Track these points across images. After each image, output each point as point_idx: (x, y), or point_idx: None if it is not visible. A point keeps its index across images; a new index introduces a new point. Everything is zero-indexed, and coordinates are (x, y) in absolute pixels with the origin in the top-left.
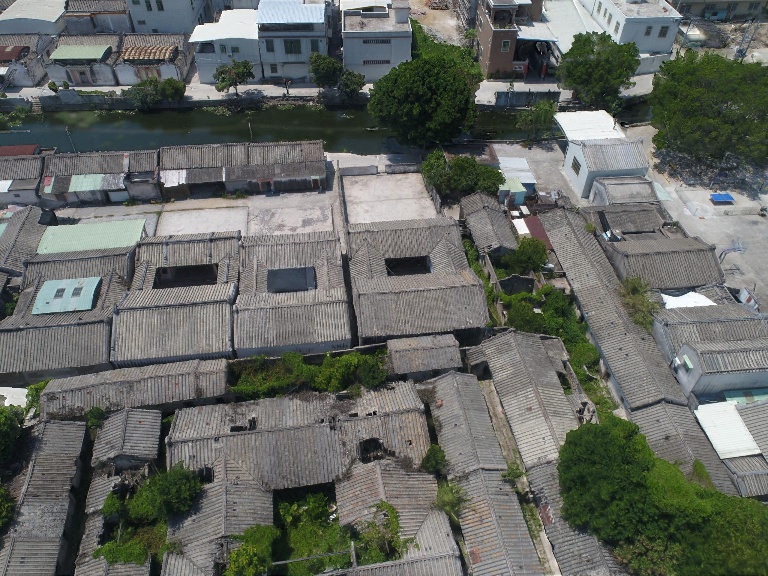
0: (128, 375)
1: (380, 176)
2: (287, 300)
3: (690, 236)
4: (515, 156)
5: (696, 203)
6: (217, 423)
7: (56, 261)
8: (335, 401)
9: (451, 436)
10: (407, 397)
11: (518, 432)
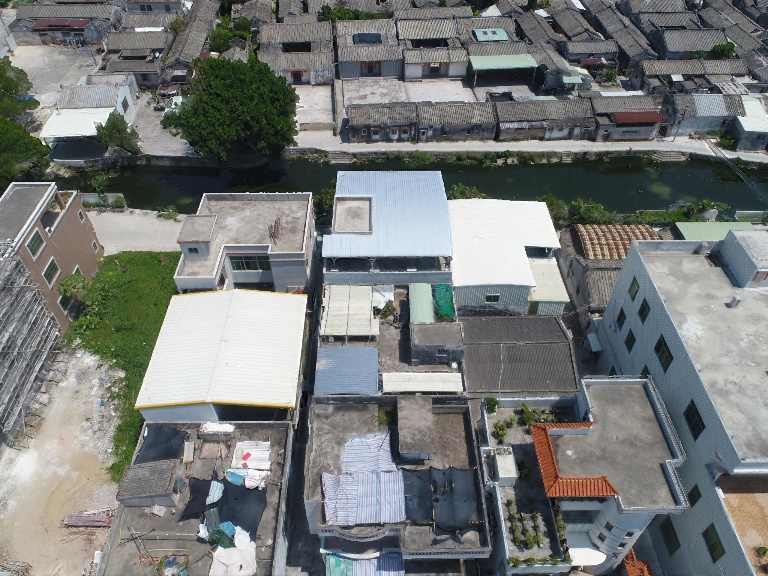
0: (437, 11)
1: (299, 129)
2: (368, 26)
3: (106, 50)
4: (160, 144)
5: (48, 101)
6: (392, 1)
7: (509, 42)
8: (344, 7)
9: (298, 5)
10: (313, 5)
11: (270, 4)
